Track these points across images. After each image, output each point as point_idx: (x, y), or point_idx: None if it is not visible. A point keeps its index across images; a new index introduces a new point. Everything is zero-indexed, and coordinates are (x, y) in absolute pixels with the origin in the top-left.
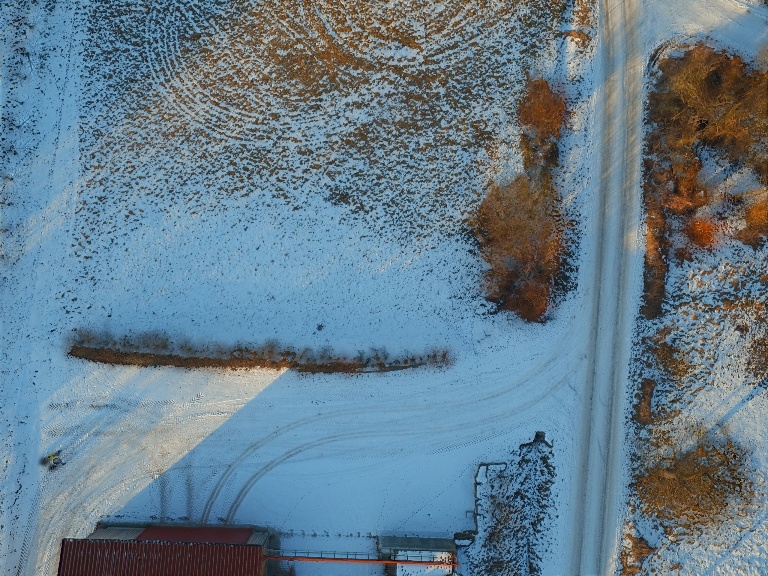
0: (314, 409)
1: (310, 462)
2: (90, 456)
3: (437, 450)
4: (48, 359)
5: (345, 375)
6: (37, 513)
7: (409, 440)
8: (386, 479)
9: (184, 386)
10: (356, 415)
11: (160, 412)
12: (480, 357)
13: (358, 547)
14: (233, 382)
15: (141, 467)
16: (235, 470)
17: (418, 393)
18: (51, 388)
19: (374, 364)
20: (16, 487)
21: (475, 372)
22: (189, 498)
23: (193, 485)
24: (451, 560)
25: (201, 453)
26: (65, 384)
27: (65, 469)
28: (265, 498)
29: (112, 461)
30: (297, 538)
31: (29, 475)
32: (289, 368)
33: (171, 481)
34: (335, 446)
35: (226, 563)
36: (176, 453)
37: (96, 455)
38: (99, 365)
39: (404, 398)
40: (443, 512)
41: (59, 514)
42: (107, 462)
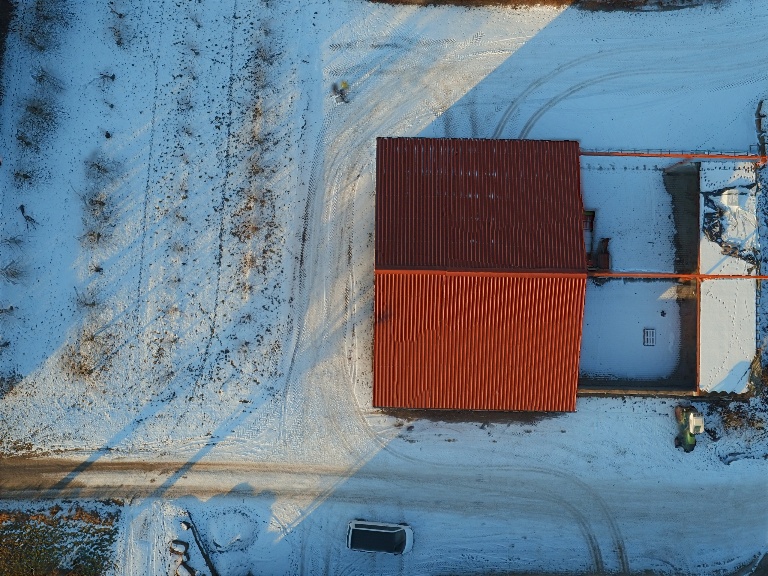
0: (594, 47)
1: (593, 98)
2: (372, 95)
3: (717, 88)
4: (327, 1)
5: (624, 14)
6: (322, 149)
7: (689, 78)
8: (668, 115)
9: (464, 25)
10: (636, 53)
11: (441, 50)
12: (753, 1)
13: (644, 180)
14: (513, 21)
15: (424, 105)
16: (518, 106)
17: (695, 33)
18: (331, 29)
19: (652, 3)
20: (302, 122)
21: (749, 15)
22: (473, 134)
23: (476, 122)
24: (754, 170)
25: (483, 90)
26: (345, 25)
27: (348, 107)
28: (549, 133)
29: (395, 99)
30: (583, 172)
31: (313, 113)
32: (569, 6)
33: (454, 118)
34: (617, 82)
35: (543, 156)
36: (458, 90)
37: (378, 93)
38: (378, 6)
39: (682, 37)
40: (727, 146)
41: (344, 151)
42: (389, 100)
